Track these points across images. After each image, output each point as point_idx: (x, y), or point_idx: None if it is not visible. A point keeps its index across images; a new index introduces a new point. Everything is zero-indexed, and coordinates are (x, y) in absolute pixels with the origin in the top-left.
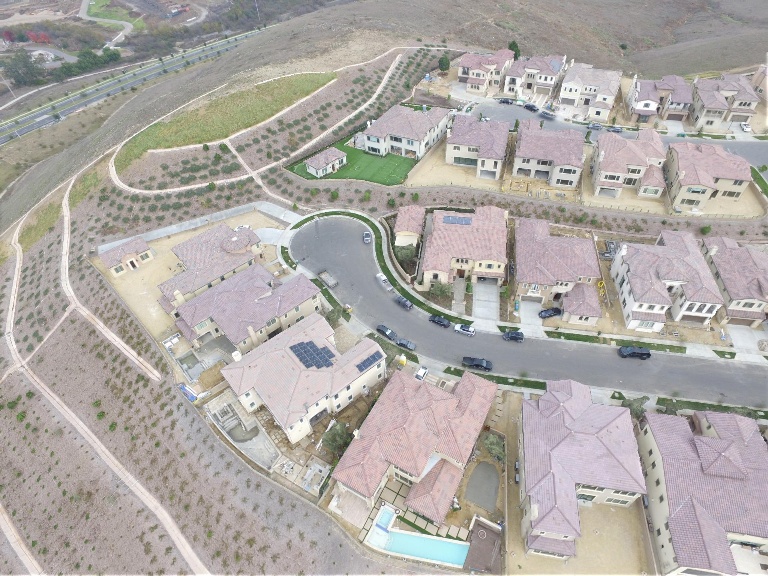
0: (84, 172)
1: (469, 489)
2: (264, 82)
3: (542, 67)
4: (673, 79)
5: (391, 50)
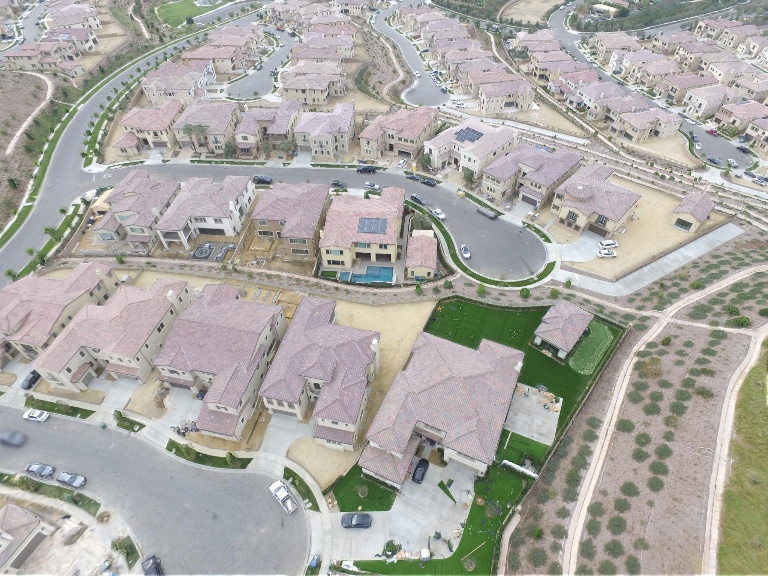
0: None
1: None
2: None
3: None
4: None
5: None
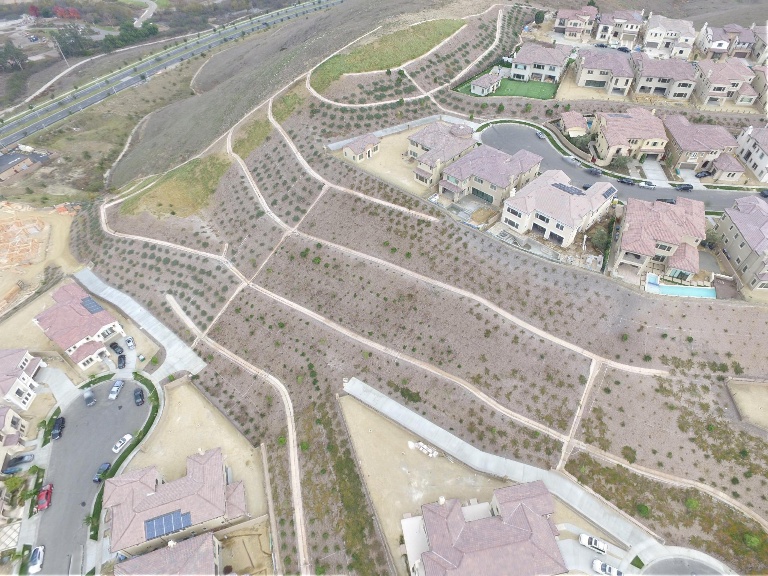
0: (281, 95)
1: (699, 264)
2: (415, 24)
3: (628, 18)
4: (734, 26)
5: (493, 6)
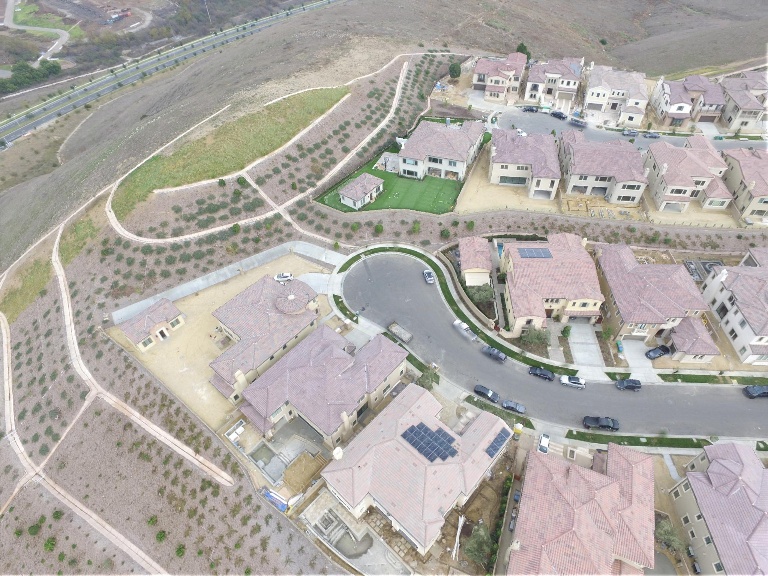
0: (74, 220)
1: None
2: (274, 102)
3: (563, 71)
4: (698, 79)
5: (396, 58)
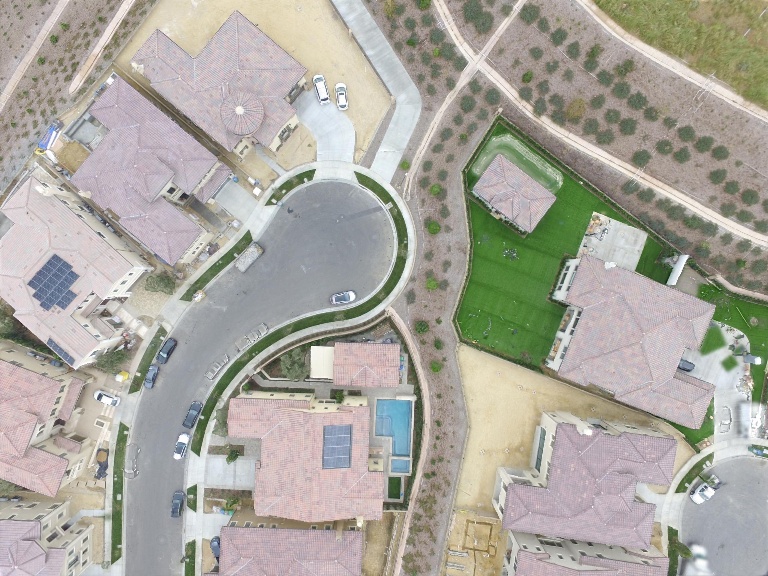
0: None
1: None
2: None
3: None
4: None
5: None
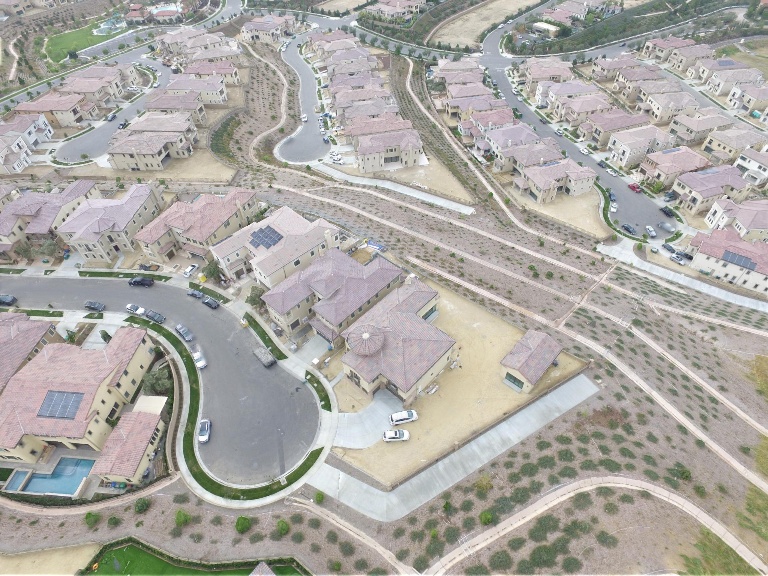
0: None
1: None
2: None
3: None
4: None
5: None
